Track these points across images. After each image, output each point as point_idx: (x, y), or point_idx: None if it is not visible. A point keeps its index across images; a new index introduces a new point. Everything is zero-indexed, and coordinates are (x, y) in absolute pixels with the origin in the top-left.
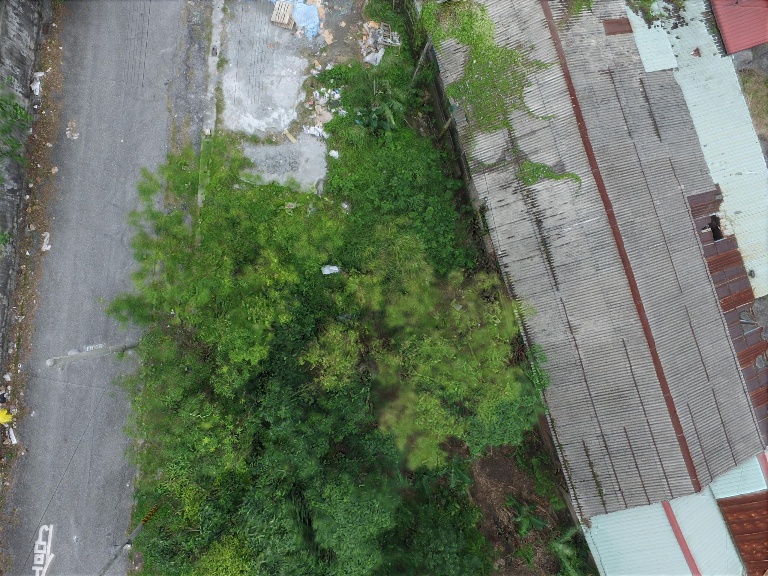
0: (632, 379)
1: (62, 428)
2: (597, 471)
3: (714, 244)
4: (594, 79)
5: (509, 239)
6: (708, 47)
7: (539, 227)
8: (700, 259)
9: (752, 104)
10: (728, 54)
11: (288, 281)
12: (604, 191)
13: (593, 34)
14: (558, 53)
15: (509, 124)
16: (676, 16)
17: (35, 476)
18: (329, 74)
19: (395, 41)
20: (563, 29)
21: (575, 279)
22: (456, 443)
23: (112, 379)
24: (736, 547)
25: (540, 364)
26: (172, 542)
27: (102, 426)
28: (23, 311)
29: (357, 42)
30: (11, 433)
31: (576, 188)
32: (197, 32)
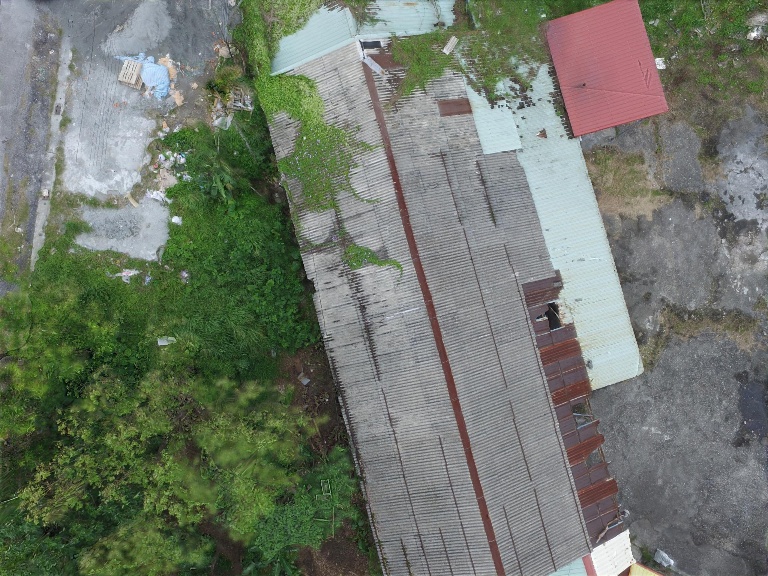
0: (447, 478)
1: None
2: (414, 572)
3: (550, 333)
4: (422, 163)
5: (335, 323)
6: (555, 128)
7: (363, 313)
8: (532, 350)
9: (614, 181)
10: (575, 136)
11: (118, 353)
12: (423, 281)
13: (425, 115)
14: (382, 136)
15: (336, 205)
16: (523, 96)
17: None
18: (174, 138)
19: (247, 105)
20: (390, 111)
21: (395, 370)
22: None
23: None
24: None
25: (362, 455)
26: None
27: None
28: None
29: (208, 105)
30: None
31: (397, 276)
32: (41, 89)
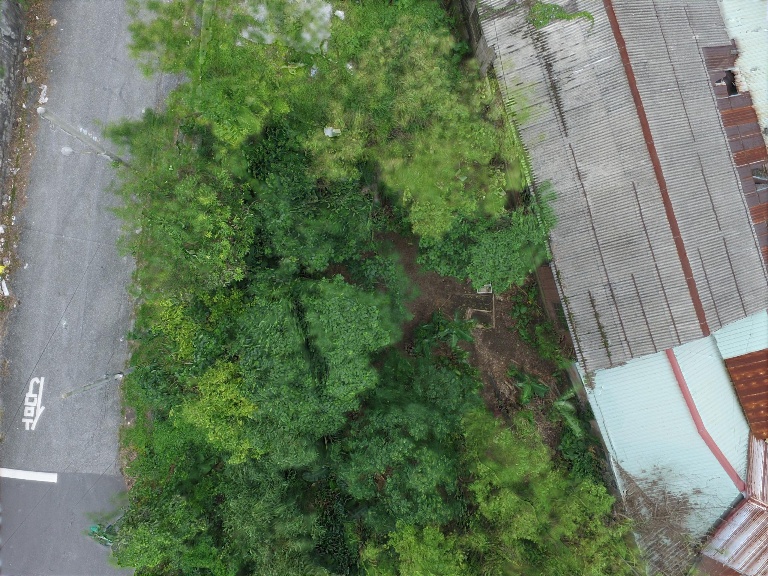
0: (641, 223)
1: (55, 281)
2: (603, 322)
3: (728, 98)
4: None
5: (518, 86)
6: None
7: (549, 71)
8: (714, 110)
9: None
10: None
11: (290, 138)
12: (617, 28)
13: None
14: None
15: None
16: None
17: (27, 328)
18: None
19: None
20: None
21: (585, 123)
22: (458, 315)
23: (108, 233)
24: (743, 408)
25: (546, 214)
26: (165, 371)
27: (96, 280)
28: (18, 163)
29: None
30: (3, 285)
31: (588, 27)
32: None
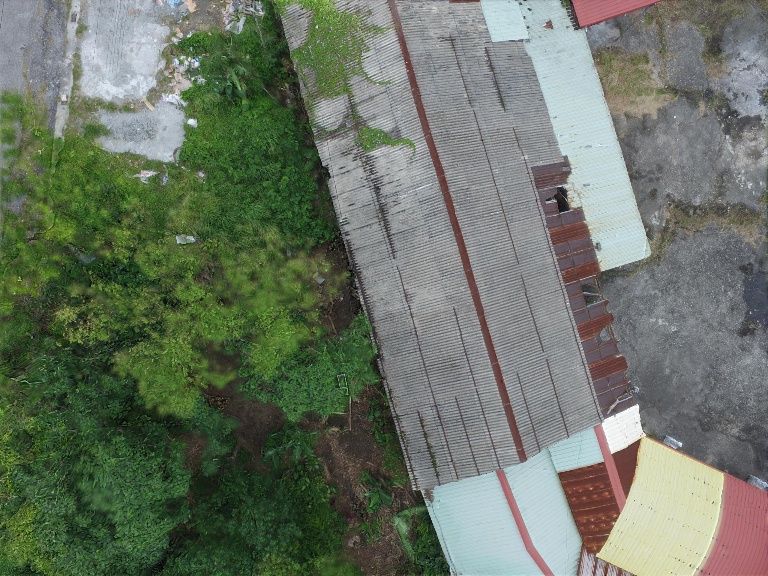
0: (462, 348)
1: None
2: (431, 442)
3: (559, 215)
4: (433, 46)
5: (350, 207)
6: (561, 19)
7: (377, 194)
8: (542, 230)
9: (619, 81)
10: (581, 27)
11: (138, 249)
12: (436, 157)
13: (434, 1)
14: (393, 18)
15: (349, 90)
16: None
17: None
18: (187, 41)
19: (258, 10)
20: None
21: (410, 247)
22: (314, 418)
23: None
24: (576, 522)
25: (378, 333)
26: None
27: None
28: None
29: (220, 11)
30: None
31: (410, 154)
32: None
